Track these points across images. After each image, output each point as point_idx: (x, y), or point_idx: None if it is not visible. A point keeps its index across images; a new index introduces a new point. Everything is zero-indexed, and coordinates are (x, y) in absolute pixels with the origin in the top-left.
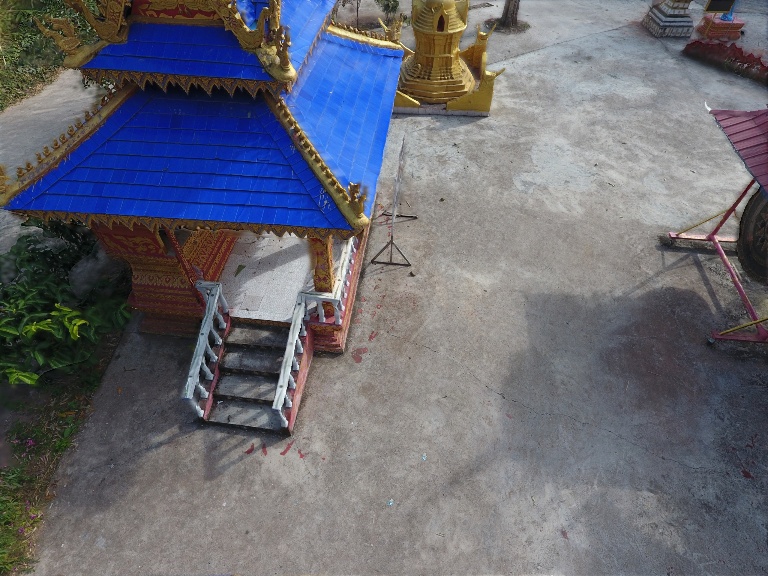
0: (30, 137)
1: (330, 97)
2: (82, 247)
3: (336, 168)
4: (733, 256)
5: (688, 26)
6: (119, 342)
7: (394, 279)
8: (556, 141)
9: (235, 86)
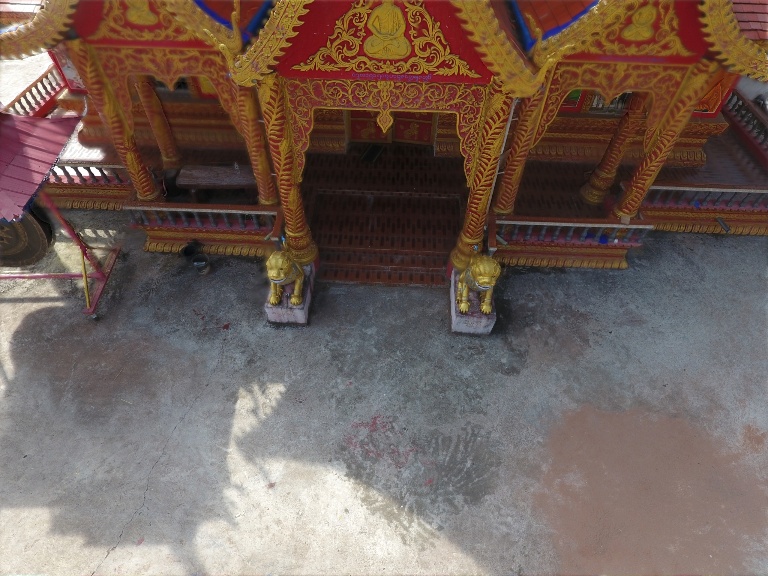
0: None
1: None
2: None
3: None
4: None
5: None
6: None
7: None
8: None
9: None
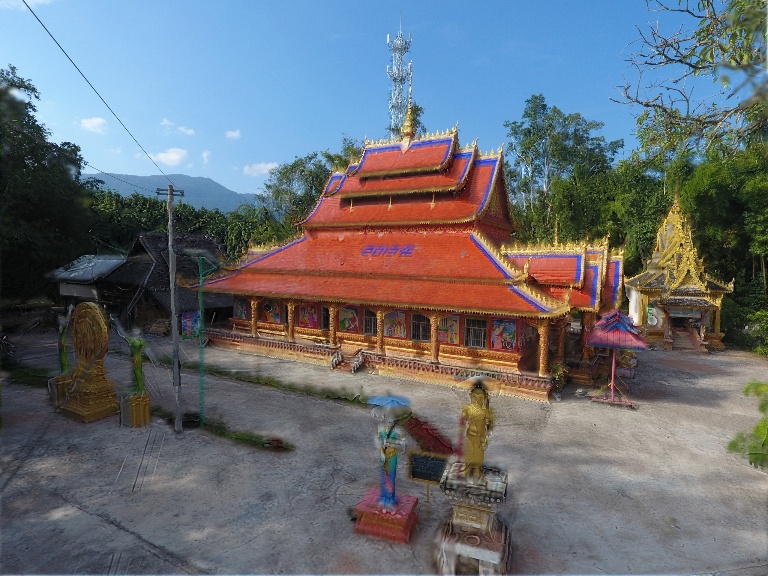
0: None
1: None
2: None
3: None
4: None
5: None
6: None
7: None
8: (704, 453)
9: None
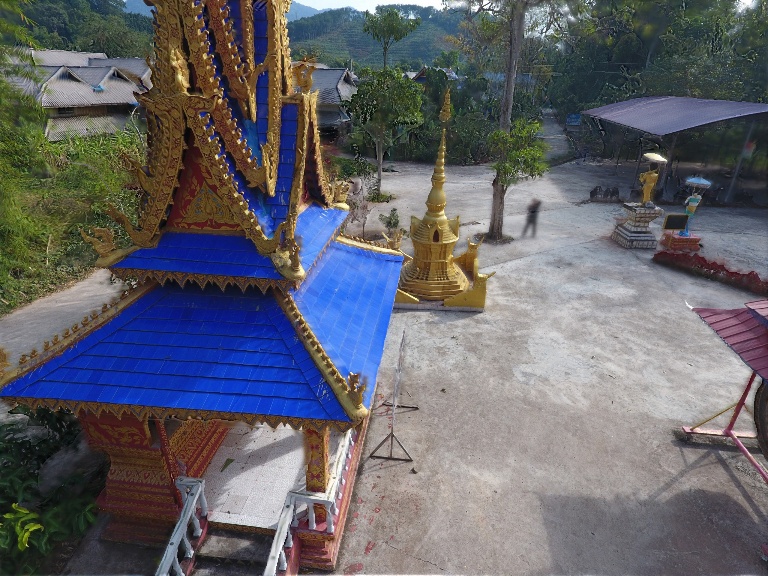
0: (48, 326)
1: (335, 294)
2: (64, 437)
3: (337, 358)
4: (757, 454)
5: (652, 240)
6: (74, 553)
7: (394, 476)
8: (550, 335)
9: (248, 283)
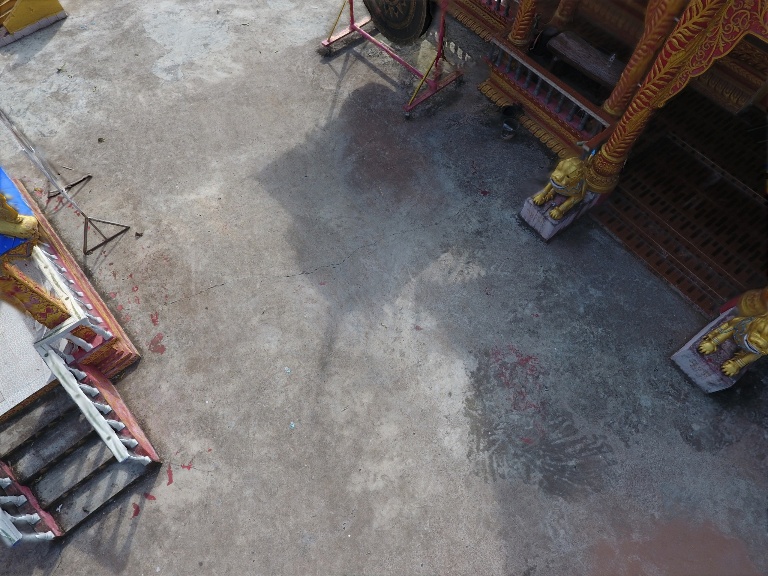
0: None
1: None
2: None
3: None
4: (377, 34)
5: None
6: None
7: (125, 253)
8: (162, 7)
9: None
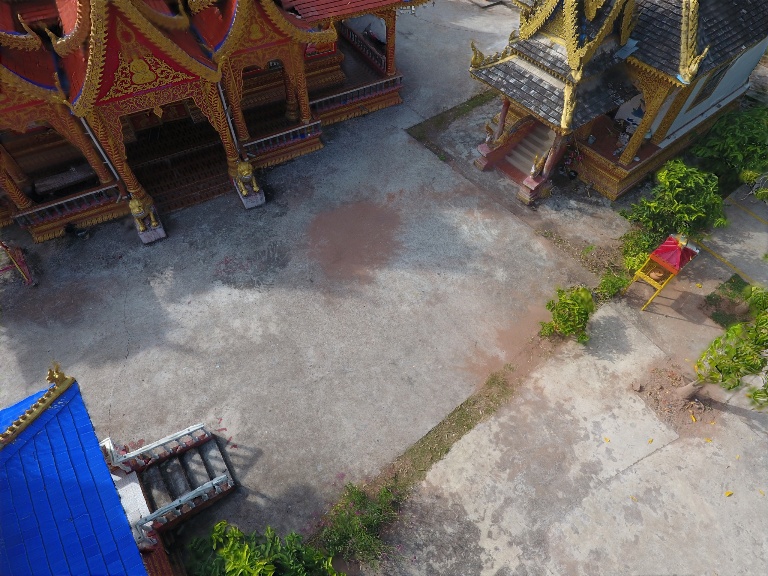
0: None
1: None
2: None
3: None
4: None
5: None
6: None
7: None
8: None
9: None
